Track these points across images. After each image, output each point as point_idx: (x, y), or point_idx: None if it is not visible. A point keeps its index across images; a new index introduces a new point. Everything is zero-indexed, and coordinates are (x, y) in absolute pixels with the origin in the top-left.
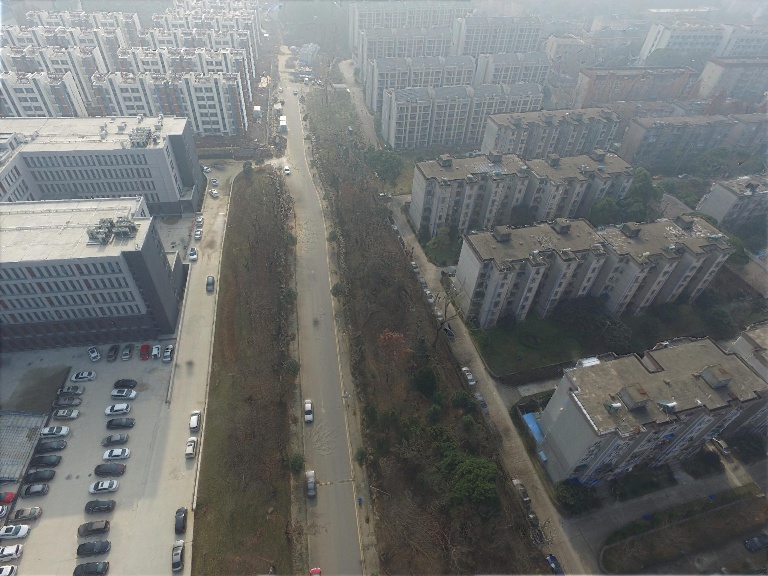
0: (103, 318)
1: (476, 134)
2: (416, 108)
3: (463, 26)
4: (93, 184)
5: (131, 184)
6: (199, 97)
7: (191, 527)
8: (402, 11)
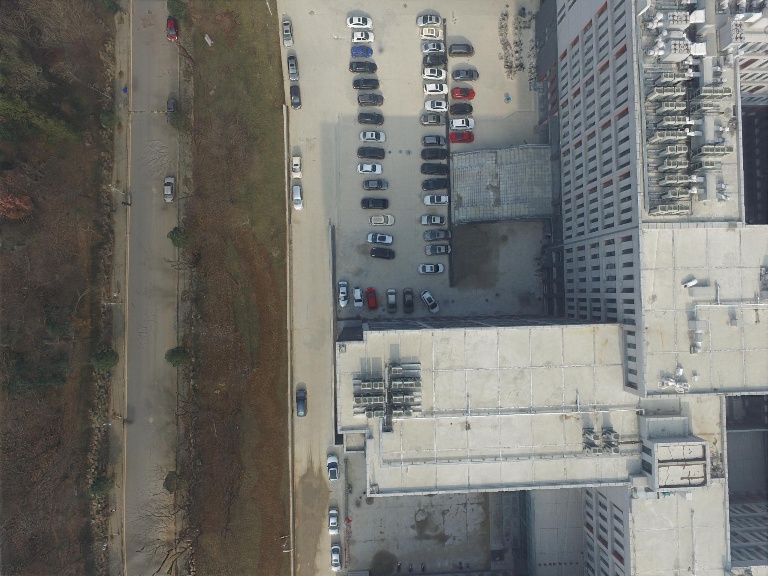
0: None
1: None
2: None
3: None
4: None
5: None
6: None
7: (287, 92)
8: None
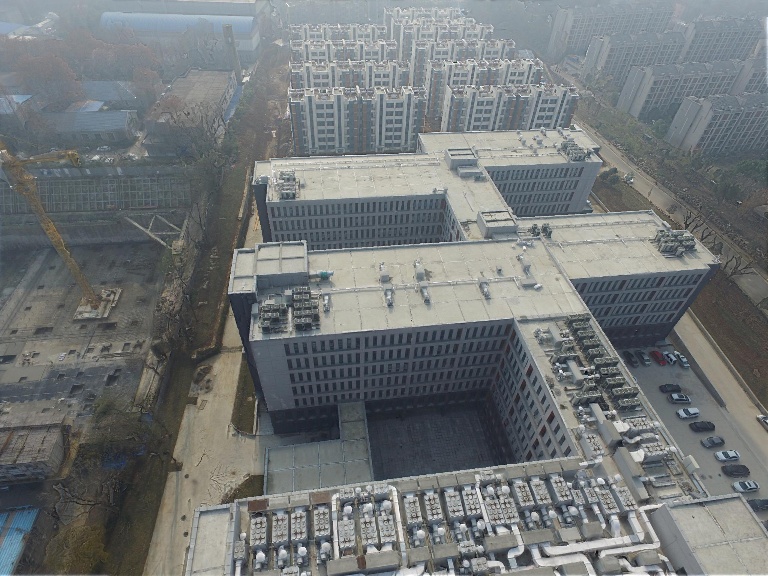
0: (636, 326)
1: (764, 140)
2: (727, 116)
3: (690, 31)
4: (522, 196)
5: (553, 195)
6: (541, 108)
7: None
8: (611, 16)
